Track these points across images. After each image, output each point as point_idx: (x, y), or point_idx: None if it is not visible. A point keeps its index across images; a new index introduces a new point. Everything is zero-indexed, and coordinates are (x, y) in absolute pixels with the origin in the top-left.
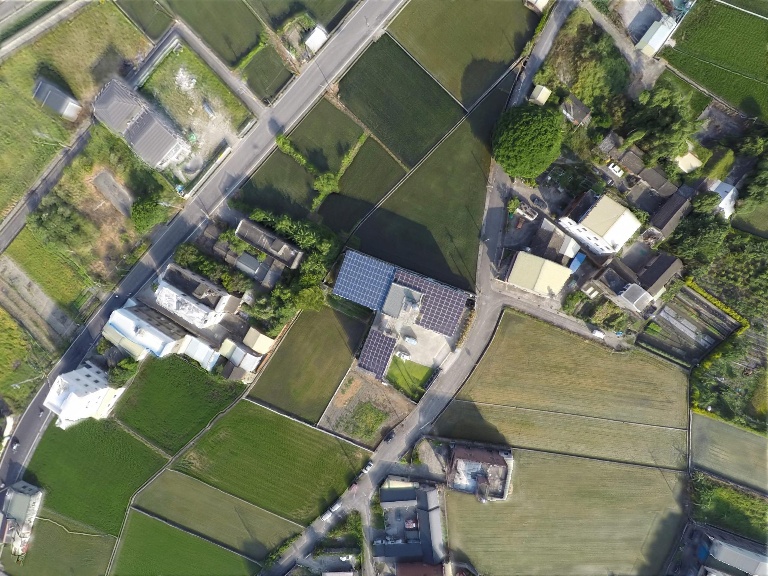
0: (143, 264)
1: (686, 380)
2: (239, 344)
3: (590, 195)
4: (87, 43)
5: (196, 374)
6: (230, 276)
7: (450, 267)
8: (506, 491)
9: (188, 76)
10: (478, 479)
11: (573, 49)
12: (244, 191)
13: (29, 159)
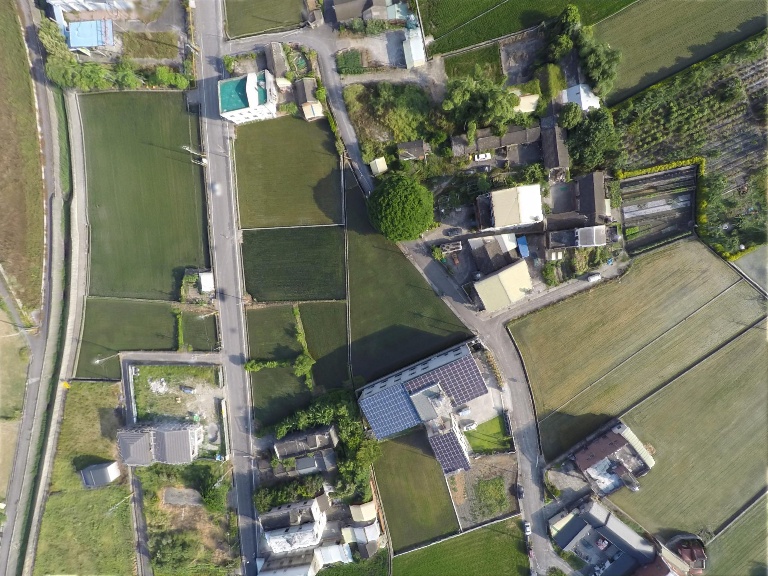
0: (243, 526)
1: (699, 244)
2: (353, 525)
3: (482, 199)
4: (83, 419)
5: (346, 569)
6: (303, 486)
7: (439, 334)
8: (648, 457)
9: (156, 380)
10: (616, 473)
11: (369, 115)
12: (258, 418)
13: (117, 524)
